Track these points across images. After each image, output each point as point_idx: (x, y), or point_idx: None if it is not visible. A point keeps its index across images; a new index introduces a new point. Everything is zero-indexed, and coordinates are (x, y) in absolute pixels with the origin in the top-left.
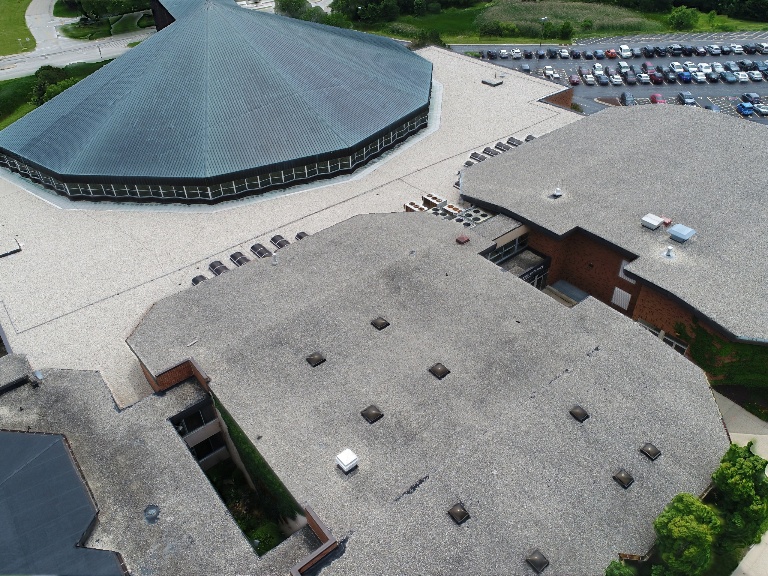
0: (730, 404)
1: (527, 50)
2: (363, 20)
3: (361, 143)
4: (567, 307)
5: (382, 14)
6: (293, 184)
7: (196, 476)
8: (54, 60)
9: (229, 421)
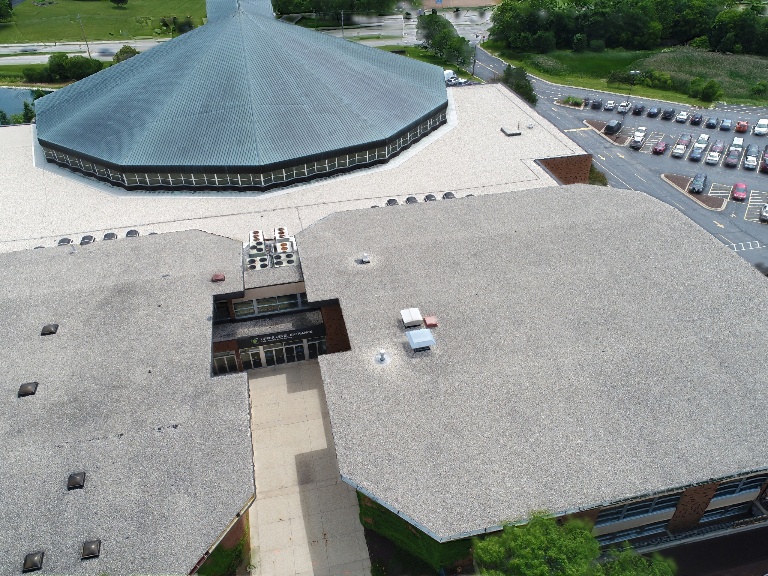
0: (362, 556)
1: (638, 105)
2: (512, 48)
3: (277, 164)
4: (210, 375)
5: (534, 45)
6: (205, 189)
7: None
8: None
9: None
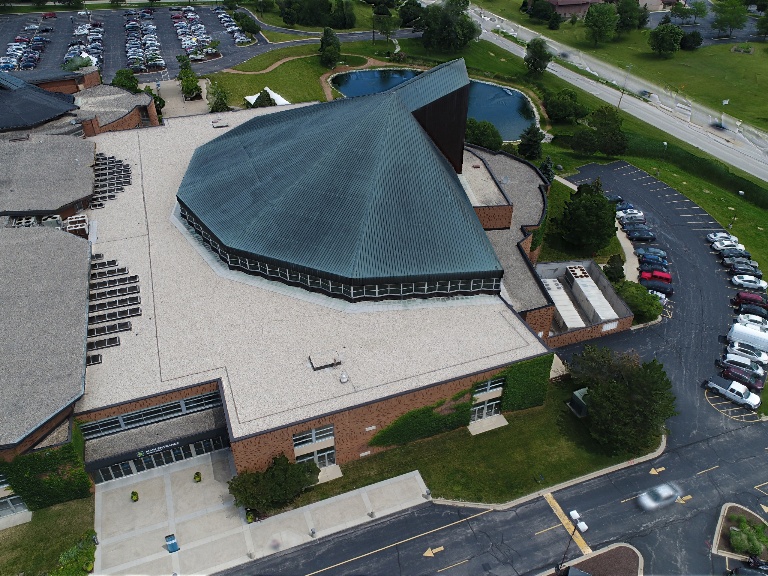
0: None
1: None
2: None
3: None
4: None
5: None
6: None
7: None
8: None
9: None
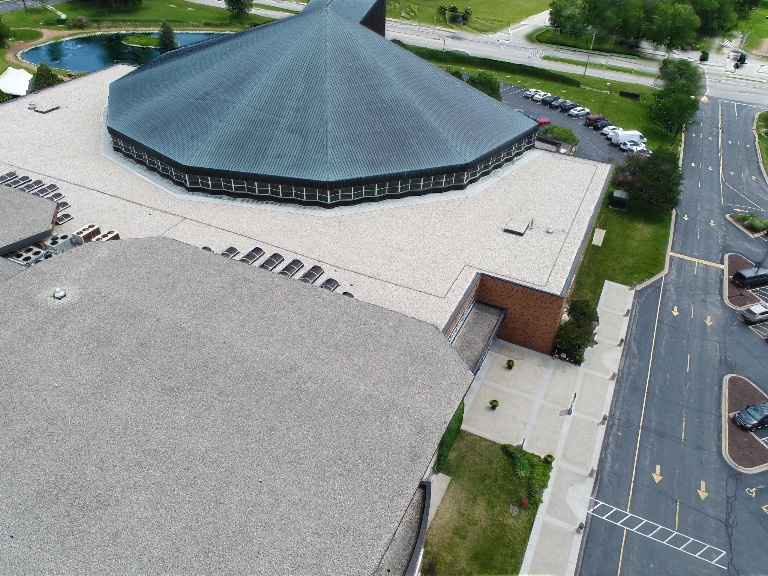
0: None
1: None
2: None
3: (202, 169)
4: None
5: None
6: (156, 171)
7: None
8: (467, 45)
9: None
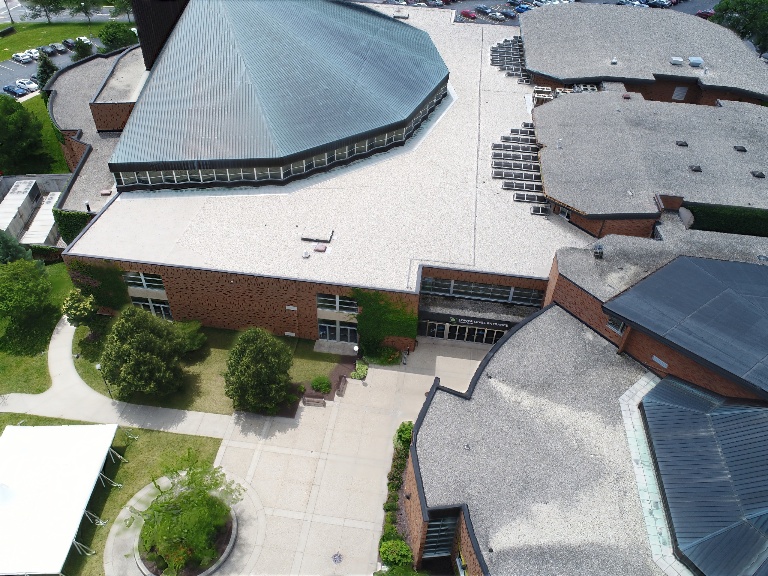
0: None
1: None
2: None
3: None
4: (721, 107)
5: None
6: None
7: (746, 238)
8: None
9: (719, 209)
